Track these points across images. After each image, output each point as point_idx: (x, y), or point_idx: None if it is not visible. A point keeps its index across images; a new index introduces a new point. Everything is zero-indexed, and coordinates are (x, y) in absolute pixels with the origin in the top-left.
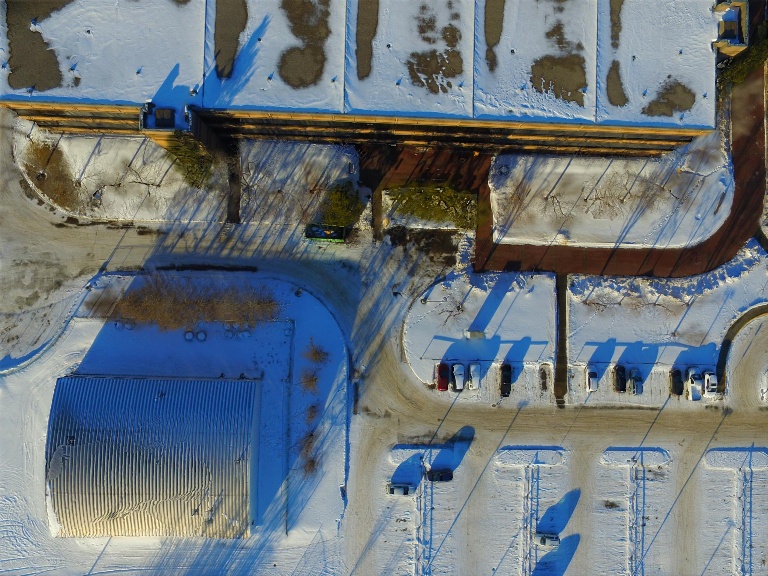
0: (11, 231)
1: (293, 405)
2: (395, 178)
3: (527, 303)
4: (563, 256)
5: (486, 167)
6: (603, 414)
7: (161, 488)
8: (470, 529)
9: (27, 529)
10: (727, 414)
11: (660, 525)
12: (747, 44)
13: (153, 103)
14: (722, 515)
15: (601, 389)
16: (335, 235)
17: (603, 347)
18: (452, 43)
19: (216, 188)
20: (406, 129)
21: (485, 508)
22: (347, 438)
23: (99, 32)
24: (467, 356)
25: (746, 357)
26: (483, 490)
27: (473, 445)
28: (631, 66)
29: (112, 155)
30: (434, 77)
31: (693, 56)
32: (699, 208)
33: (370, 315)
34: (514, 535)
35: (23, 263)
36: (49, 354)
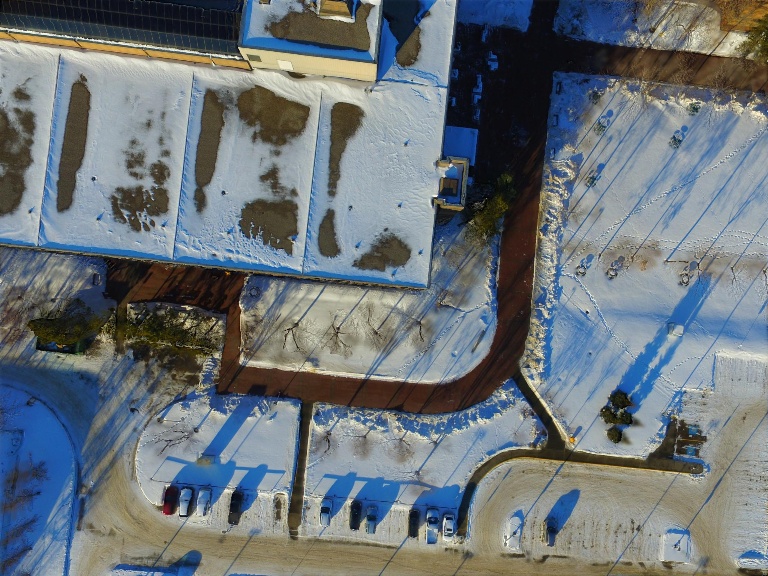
0: None
1: (14, 517)
2: (143, 292)
3: (268, 430)
4: (311, 384)
5: (238, 287)
6: (338, 548)
7: None
8: None
9: None
10: (467, 558)
11: None
12: (464, 205)
13: None
14: None
15: (337, 523)
16: (68, 349)
17: (343, 480)
18: (160, 180)
19: None
20: None
21: None
22: (68, 554)
23: None
24: (198, 480)
25: (491, 501)
26: None
27: (199, 571)
28: (347, 216)
29: None
30: (137, 214)
31: (412, 210)
32: (456, 345)
33: (104, 430)
34: None
35: None
36: None
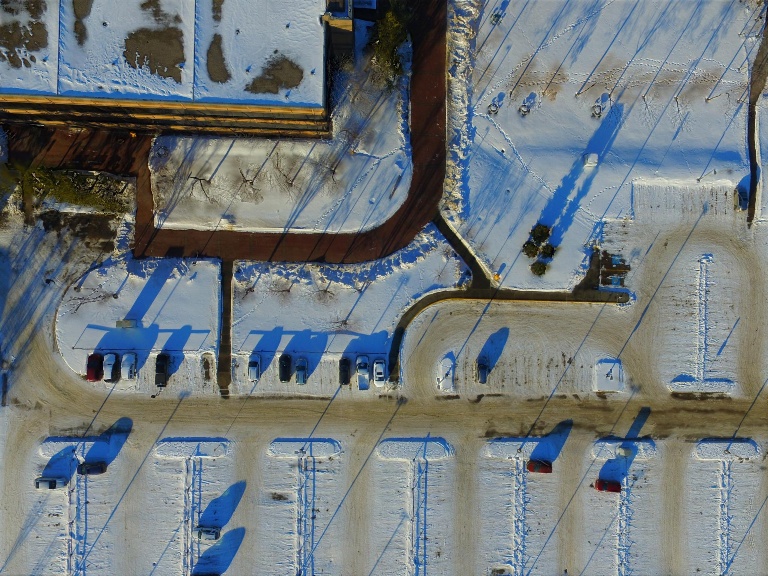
0: None
1: None
2: (47, 160)
3: (188, 290)
4: (229, 242)
5: (146, 149)
6: (270, 404)
7: None
8: (128, 523)
9: None
10: (402, 404)
11: (331, 517)
12: (351, 17)
13: None
14: (395, 506)
15: (268, 379)
16: None
17: (269, 335)
18: (37, 15)
19: None
20: (12, 107)
21: (144, 502)
22: None
23: None
24: (121, 345)
25: (421, 345)
26: (142, 483)
27: (131, 437)
28: (234, 40)
29: None
30: (16, 51)
31: (301, 30)
32: (373, 192)
33: (20, 303)
34: (175, 529)
35: None
36: None
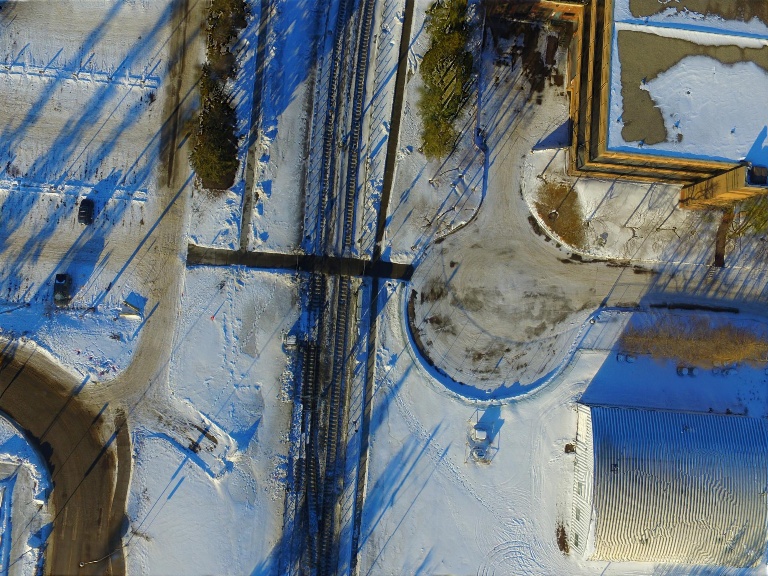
0: (522, 264)
1: None
2: None
3: None
4: None
5: None
6: None
7: (665, 516)
8: None
9: (534, 550)
10: None
11: None
12: None
13: (745, 160)
14: None
15: None
16: None
17: None
18: None
19: (707, 233)
20: None
21: None
22: None
23: (697, 93)
24: None
25: None
26: None
27: None
28: None
29: (622, 199)
30: None
31: None
32: None
33: None
34: None
35: (533, 295)
36: (557, 383)
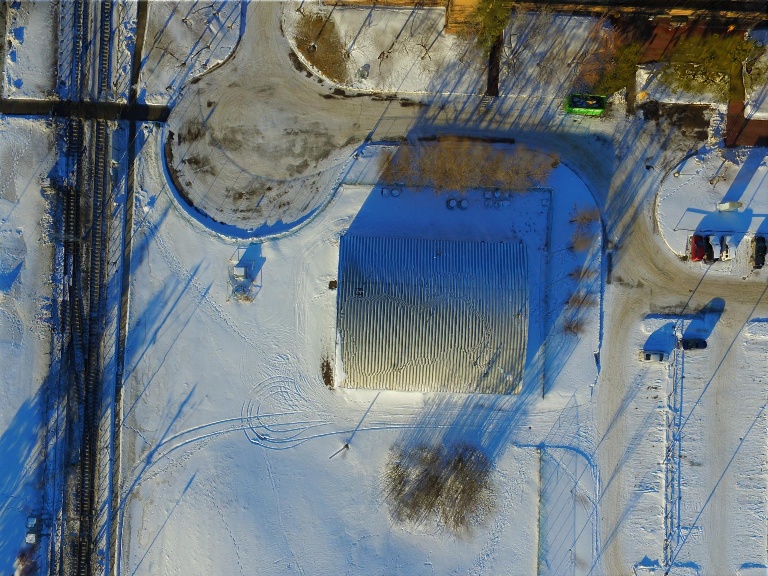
0: (282, 101)
1: (550, 273)
2: (649, 53)
3: None
4: None
5: None
6: None
7: (429, 347)
8: (719, 398)
9: (299, 385)
10: None
11: None
12: None
13: None
14: None
15: None
16: (596, 105)
17: None
18: None
19: (477, 61)
20: None
21: (734, 378)
22: (601, 306)
23: None
24: (720, 228)
25: None
26: (732, 361)
27: (723, 316)
28: None
29: (382, 26)
30: None
31: None
32: None
33: (623, 188)
34: (762, 406)
35: (294, 132)
36: (320, 219)
